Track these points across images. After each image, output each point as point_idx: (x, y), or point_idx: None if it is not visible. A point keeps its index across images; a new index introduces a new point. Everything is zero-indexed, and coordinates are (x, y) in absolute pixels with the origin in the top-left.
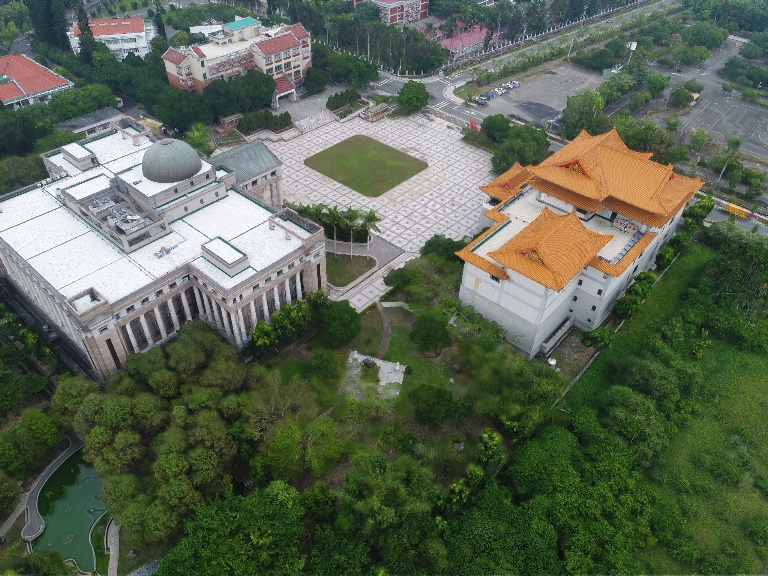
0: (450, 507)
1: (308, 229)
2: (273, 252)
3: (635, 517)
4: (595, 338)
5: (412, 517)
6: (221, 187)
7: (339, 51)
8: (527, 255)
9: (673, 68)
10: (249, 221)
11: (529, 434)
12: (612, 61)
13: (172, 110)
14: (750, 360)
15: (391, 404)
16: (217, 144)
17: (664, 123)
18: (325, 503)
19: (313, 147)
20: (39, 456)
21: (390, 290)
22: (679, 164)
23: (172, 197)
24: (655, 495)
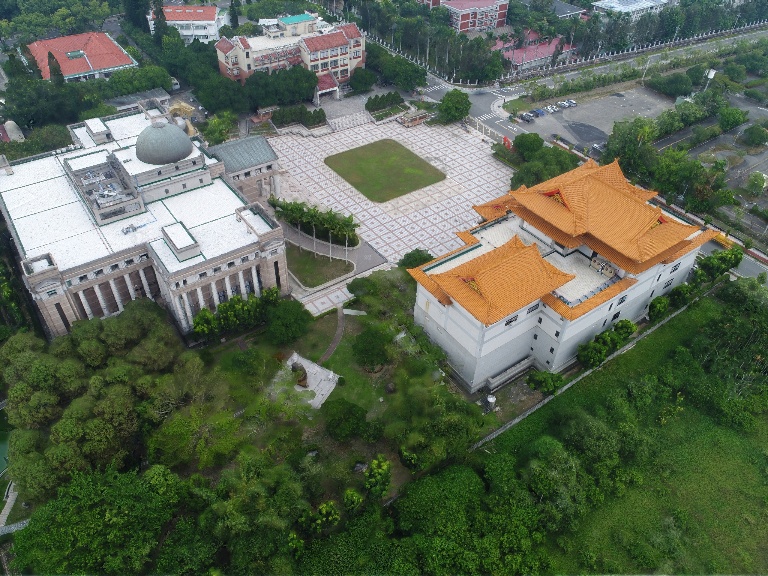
0: (315, 527)
1: (272, 226)
2: (229, 243)
3: None
4: (539, 382)
5: (266, 528)
6: (206, 174)
7: (401, 53)
8: (468, 283)
9: (762, 102)
10: (221, 210)
11: (436, 469)
12: (687, 88)
13: (212, 96)
14: (725, 437)
15: (301, 412)
16: (249, 133)
17: (727, 161)
18: (199, 496)
19: (339, 146)
20: None
21: (356, 298)
22: (727, 208)
23: (155, 178)
24: (550, 563)
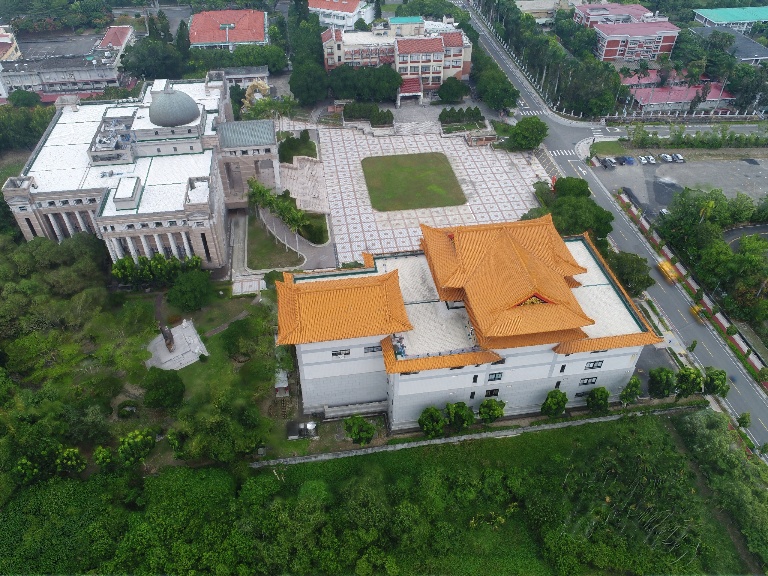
0: (58, 464)
1: None
2: (165, 206)
3: None
4: (350, 426)
5: (12, 446)
6: (196, 143)
7: (525, 72)
8: None
9: None
10: (187, 177)
11: None
12: None
13: None
14: (536, 575)
15: None
16: (318, 120)
17: None
18: None
19: (388, 149)
20: None
21: None
22: None
23: (153, 137)
24: None
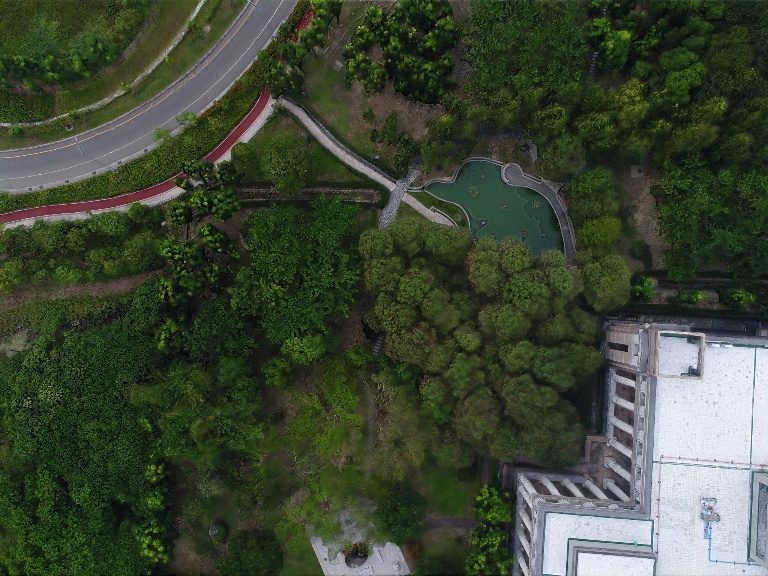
0: None
1: None
2: None
3: (26, 573)
4: None
5: None
6: None
7: None
8: None
9: None
10: None
11: None
12: None
13: None
14: None
15: None
16: None
17: None
18: None
19: None
20: (571, 214)
21: None
22: None
23: None
24: None
